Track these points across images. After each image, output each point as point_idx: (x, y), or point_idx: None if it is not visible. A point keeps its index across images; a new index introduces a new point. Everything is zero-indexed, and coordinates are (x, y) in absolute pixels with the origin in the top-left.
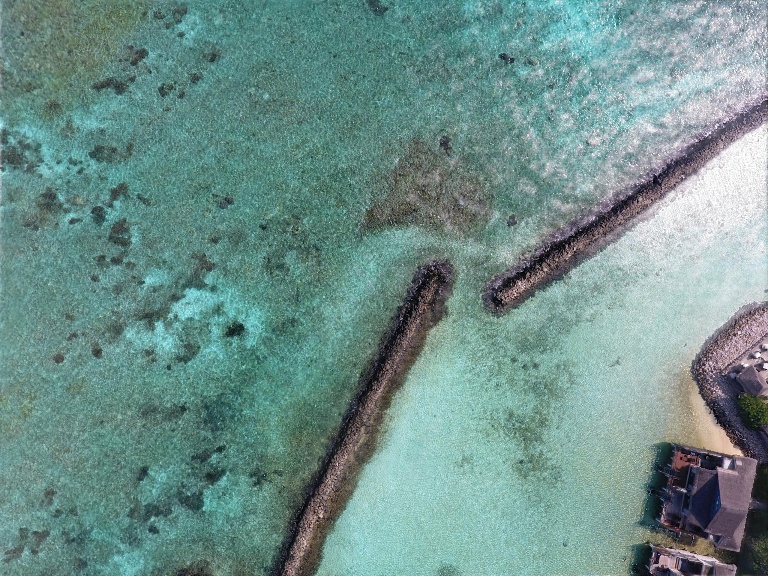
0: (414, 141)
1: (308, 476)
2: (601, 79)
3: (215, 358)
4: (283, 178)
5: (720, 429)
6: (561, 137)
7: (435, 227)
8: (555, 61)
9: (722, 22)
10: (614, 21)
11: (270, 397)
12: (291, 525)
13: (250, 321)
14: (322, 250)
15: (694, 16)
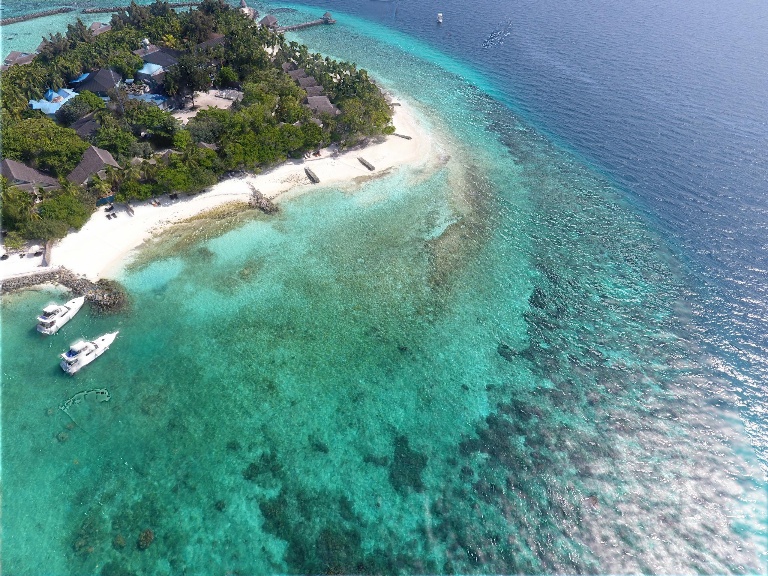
0: (81, 0)
1: None
2: None
3: None
4: (39, 0)
5: None
6: (124, 3)
7: (76, 6)
8: None
9: None
10: None
11: (0, 15)
12: None
13: (7, 9)
14: None
15: None
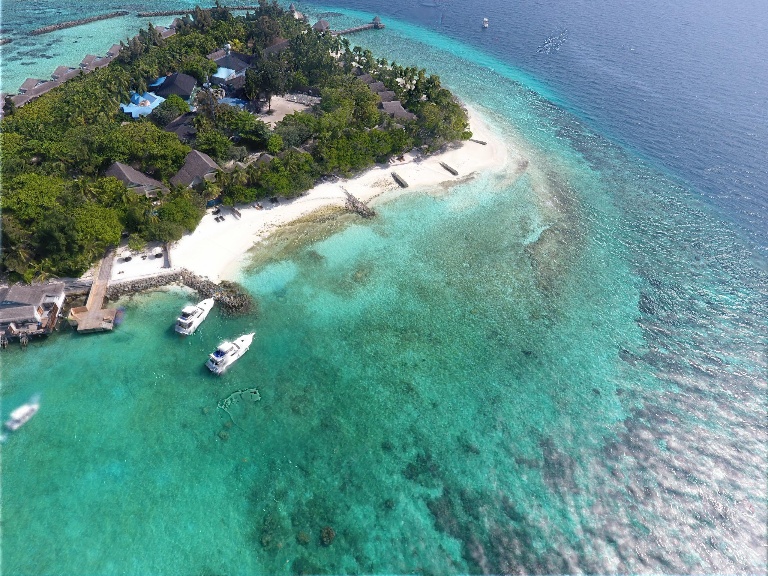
0: None
1: None
2: (191, 4)
3: (49, 14)
4: None
5: None
6: None
7: None
8: (180, 2)
9: (229, 3)
10: (199, 1)
11: None
12: None
13: None
14: None
15: (221, 2)
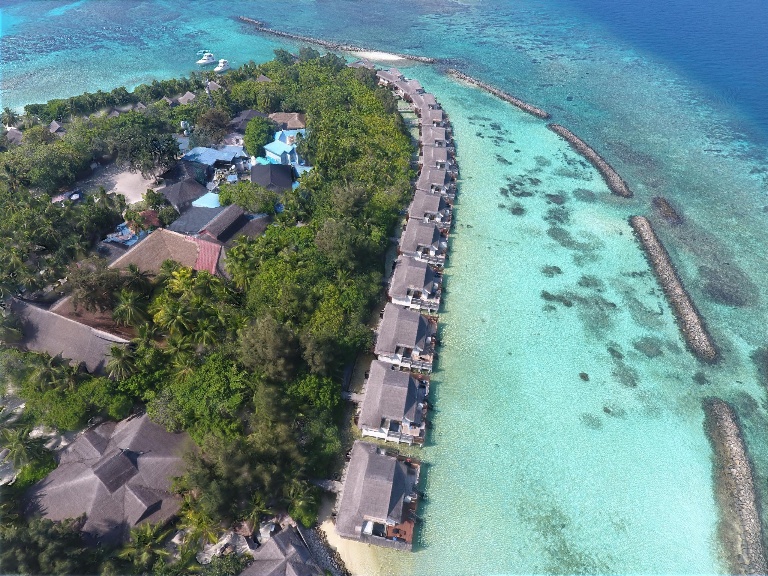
0: None
1: (765, 508)
2: None
3: None
4: None
5: (352, 570)
6: None
7: None
8: None
9: None
10: None
11: None
12: (751, 462)
13: None
14: None
15: None
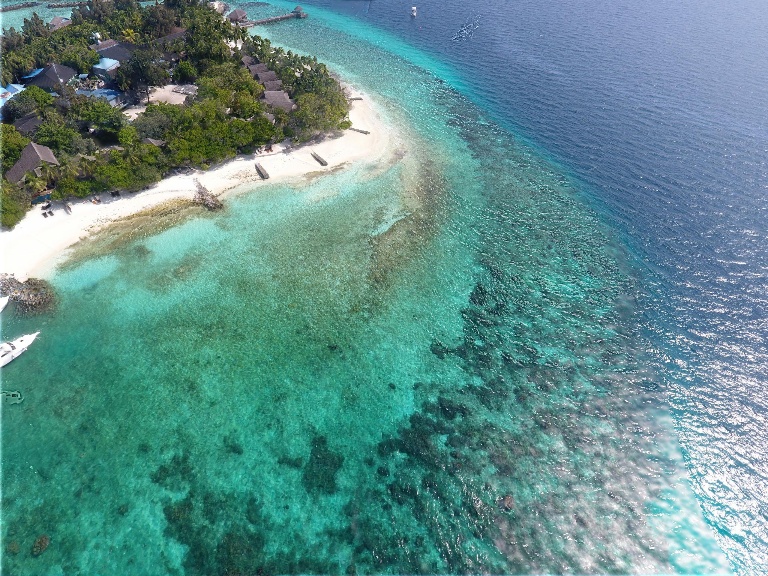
0: None
1: None
2: None
3: None
4: None
5: None
6: None
7: None
8: None
9: None
10: None
11: None
12: None
13: None
14: (5, 0)
15: None
